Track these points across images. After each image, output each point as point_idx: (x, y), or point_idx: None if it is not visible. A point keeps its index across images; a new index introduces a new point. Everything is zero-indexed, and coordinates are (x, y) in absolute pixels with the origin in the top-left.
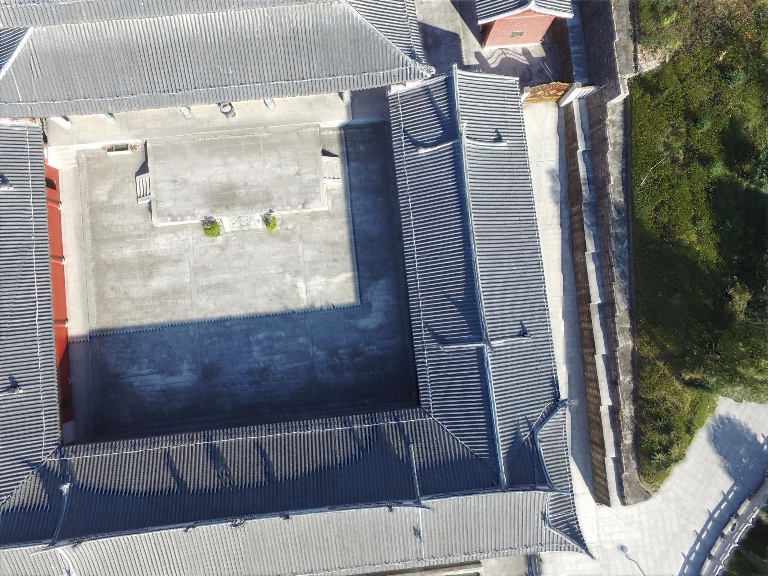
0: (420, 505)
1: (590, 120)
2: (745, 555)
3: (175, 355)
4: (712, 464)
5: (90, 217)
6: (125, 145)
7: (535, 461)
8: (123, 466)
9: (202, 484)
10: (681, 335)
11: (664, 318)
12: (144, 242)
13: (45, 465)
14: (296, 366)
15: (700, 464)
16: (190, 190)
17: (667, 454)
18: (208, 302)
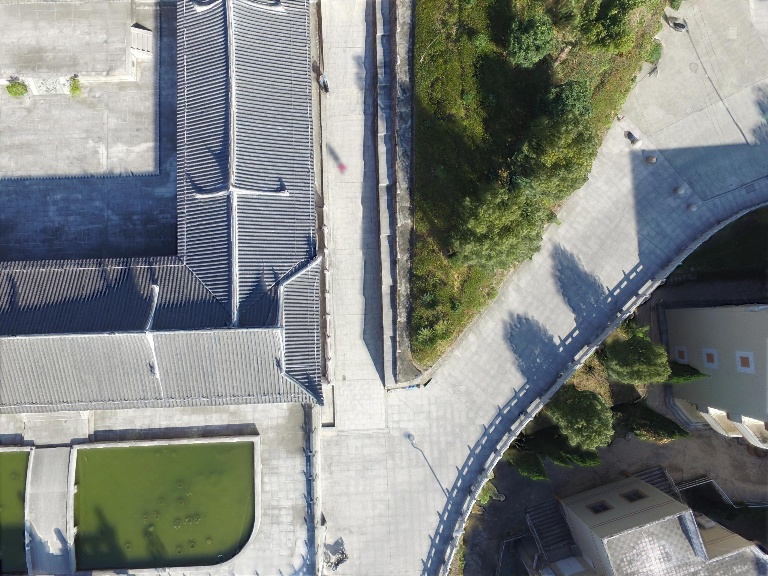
0: (140, 331)
1: (389, 5)
2: (540, 458)
3: None
4: (506, 362)
5: None
6: None
7: (272, 307)
8: None
9: None
10: (448, 210)
11: (434, 193)
12: None
13: None
14: (90, 228)
15: (494, 361)
16: None
17: (433, 330)
18: (10, 161)
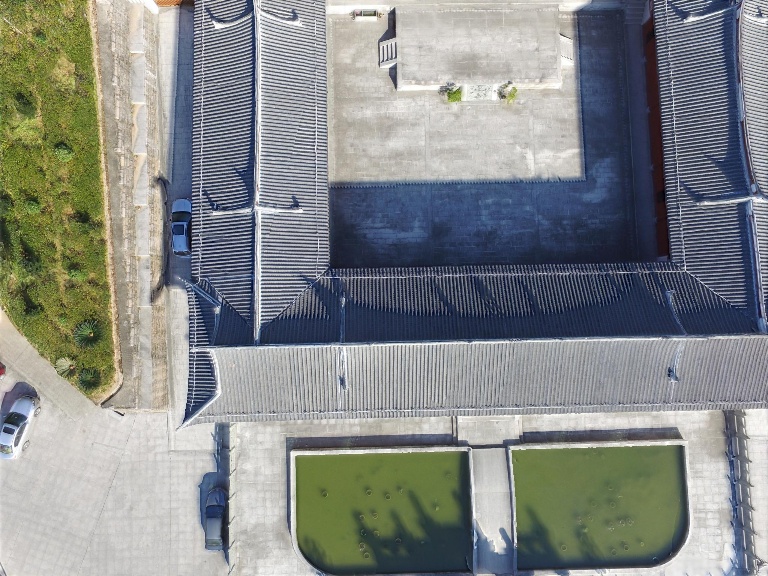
0: (695, 336)
1: None
2: None
3: (407, 212)
4: None
5: (334, 77)
6: (373, 11)
7: None
8: (393, 289)
9: (471, 309)
10: None
11: None
12: (383, 104)
13: (319, 282)
14: (522, 232)
15: None
16: (434, 57)
17: None
18: (441, 165)
